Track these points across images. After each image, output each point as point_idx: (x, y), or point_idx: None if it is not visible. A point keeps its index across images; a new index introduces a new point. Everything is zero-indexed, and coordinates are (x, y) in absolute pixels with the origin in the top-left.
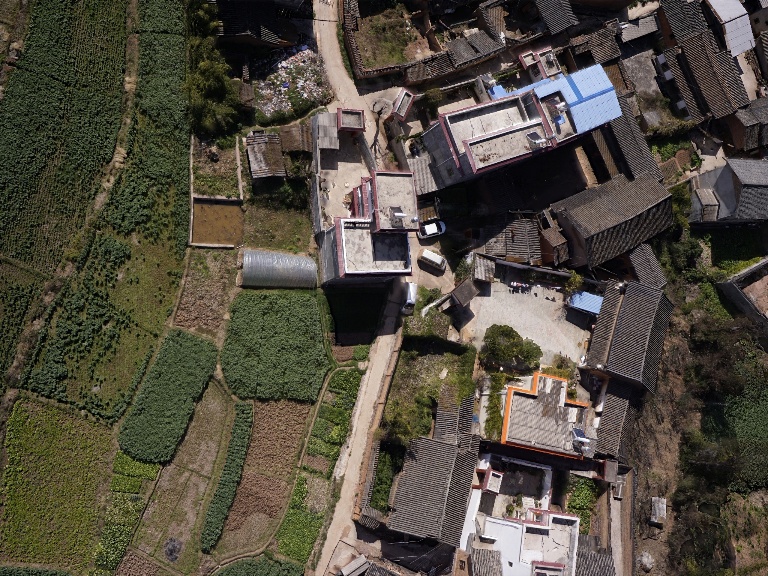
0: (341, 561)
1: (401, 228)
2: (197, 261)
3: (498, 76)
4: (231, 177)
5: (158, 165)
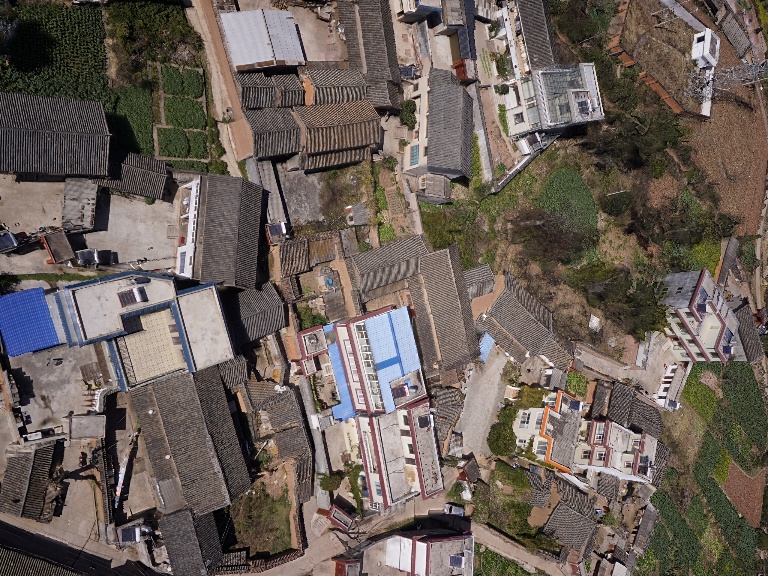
0: (570, 571)
1: None
2: None
3: (316, 402)
4: None
5: None
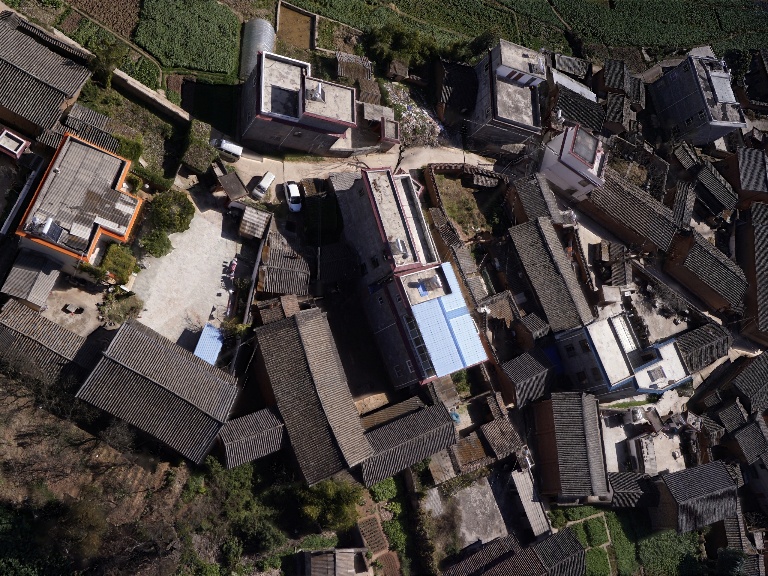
0: None
1: (306, 96)
2: (266, 2)
3: None
4: (333, 46)
5: (339, 2)
